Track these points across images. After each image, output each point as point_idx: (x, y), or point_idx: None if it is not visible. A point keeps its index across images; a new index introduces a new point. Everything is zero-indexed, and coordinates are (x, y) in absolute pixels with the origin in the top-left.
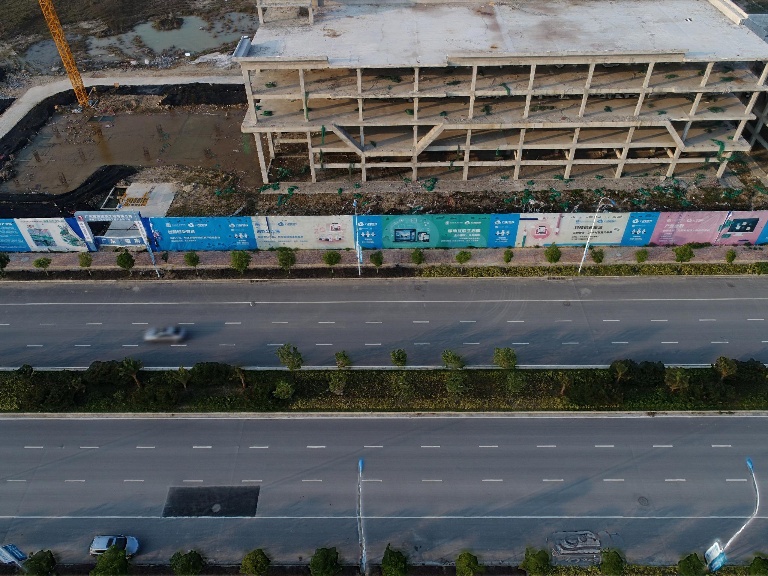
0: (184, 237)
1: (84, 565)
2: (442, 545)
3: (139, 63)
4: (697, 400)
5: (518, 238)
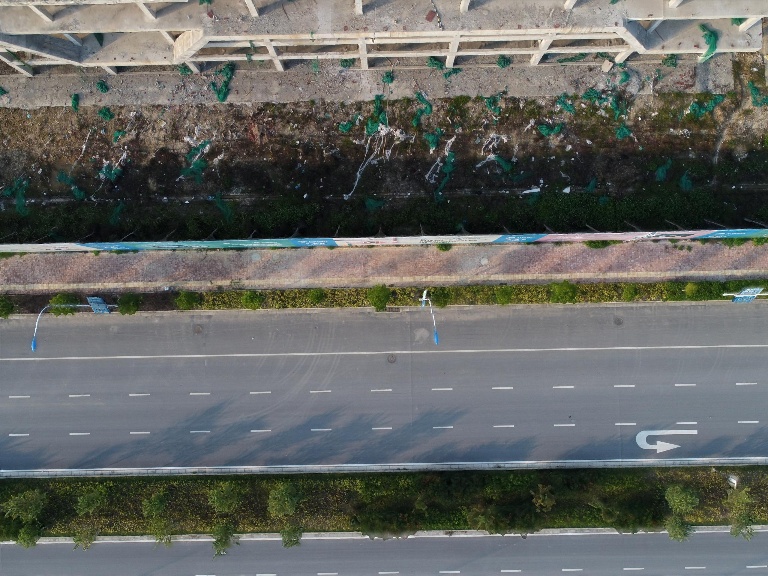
0: None
1: None
2: None
3: None
4: (499, 533)
5: (340, 244)
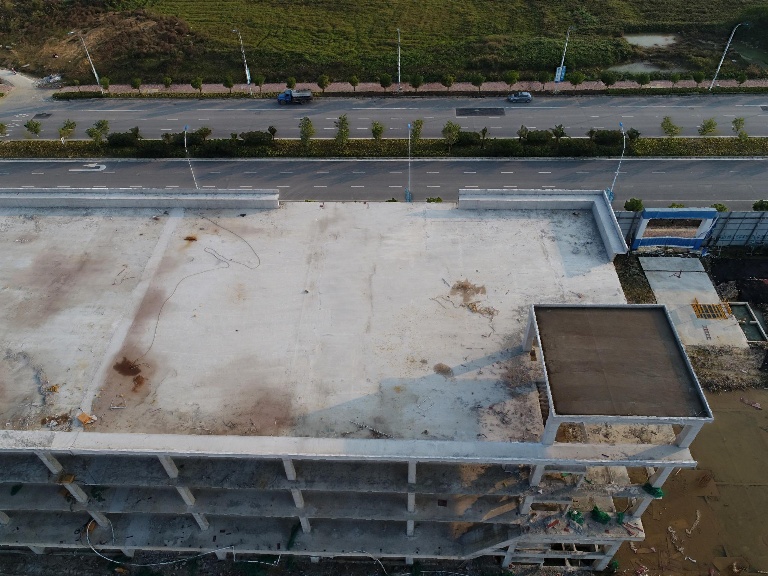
0: None
1: (530, 93)
2: (362, 102)
3: None
4: None
5: None
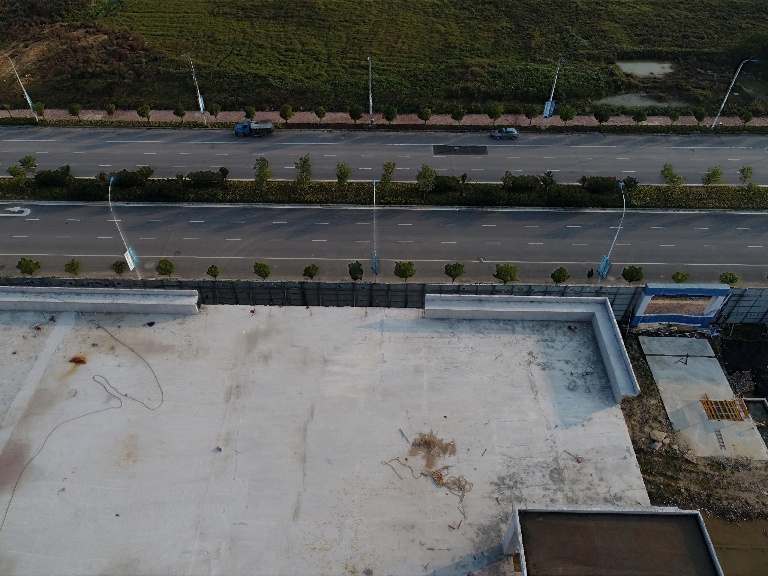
0: None
1: (516, 129)
2: (330, 136)
3: None
4: None
5: None
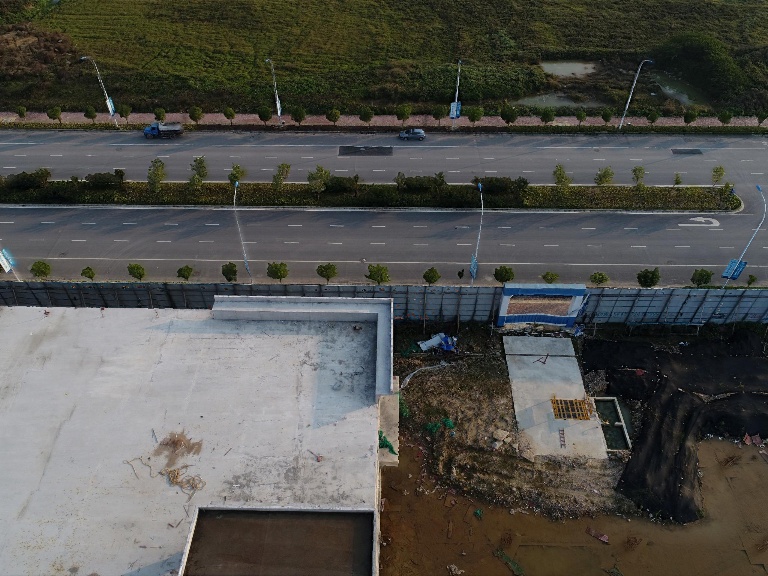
0: (454, 307)
1: (425, 130)
2: (239, 137)
3: None
4: None
5: None
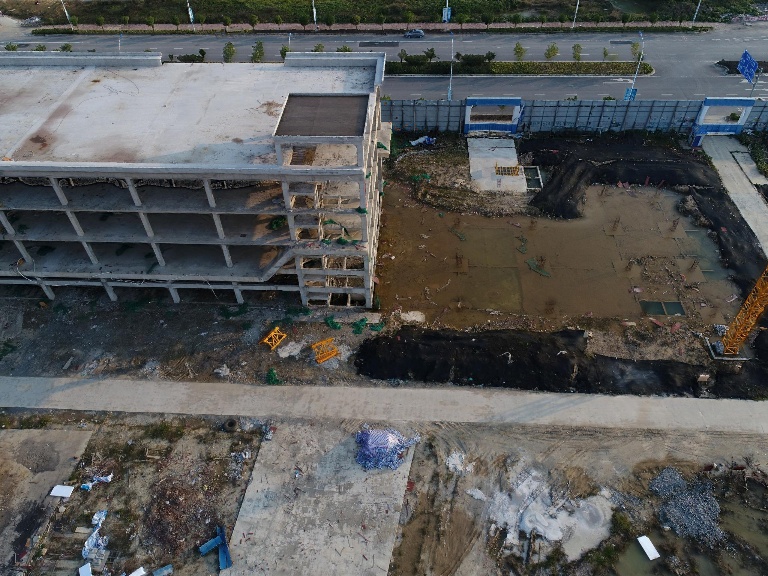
0: (434, 119)
1: (424, 31)
2: (285, 37)
3: (745, 501)
4: None
5: None
